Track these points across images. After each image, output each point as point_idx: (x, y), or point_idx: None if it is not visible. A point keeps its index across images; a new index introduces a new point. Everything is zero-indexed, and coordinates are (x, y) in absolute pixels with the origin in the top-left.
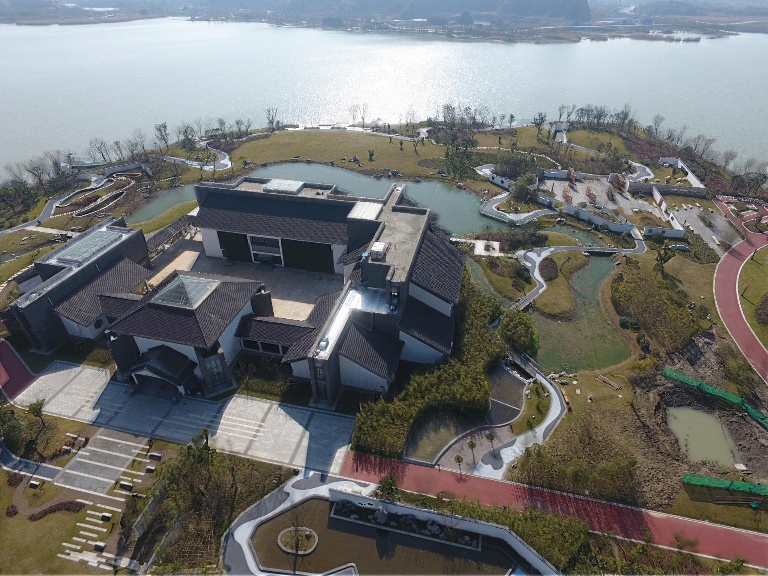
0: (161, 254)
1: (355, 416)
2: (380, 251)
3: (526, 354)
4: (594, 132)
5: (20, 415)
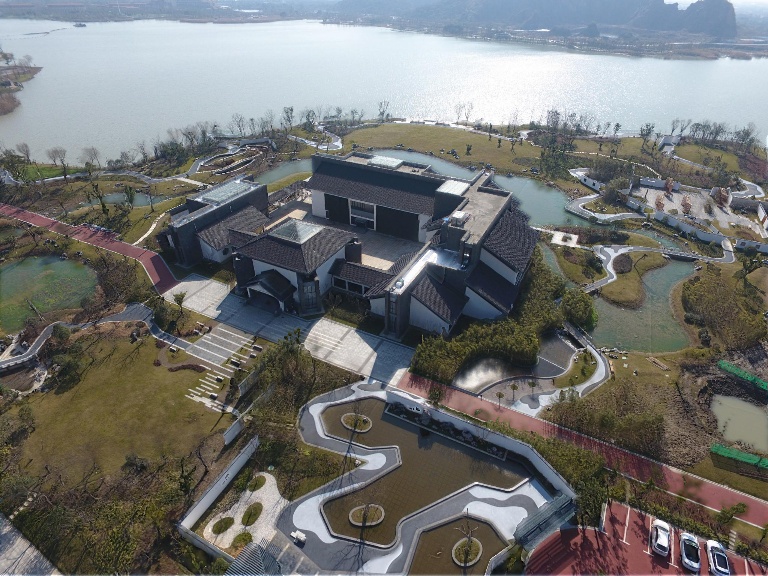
0: (277, 209)
1: None
2: (460, 218)
3: (582, 328)
4: (707, 148)
5: (166, 304)
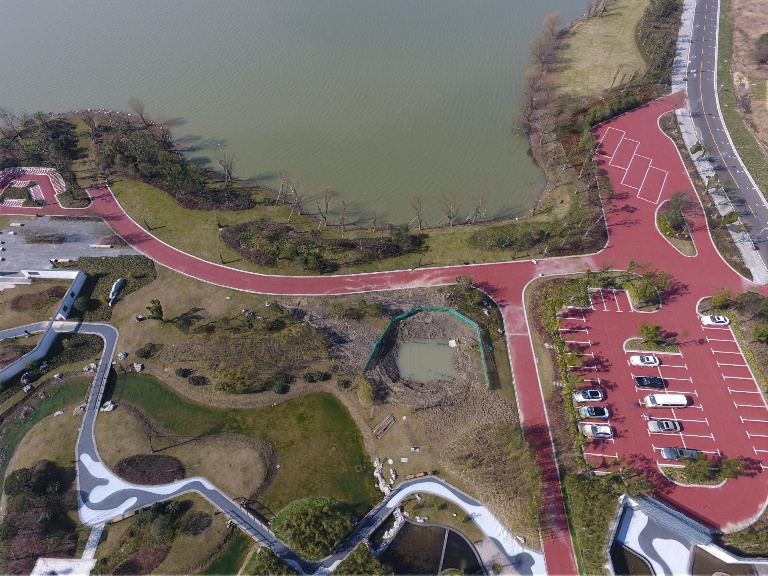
0: None
1: None
2: None
3: None
4: None
5: None
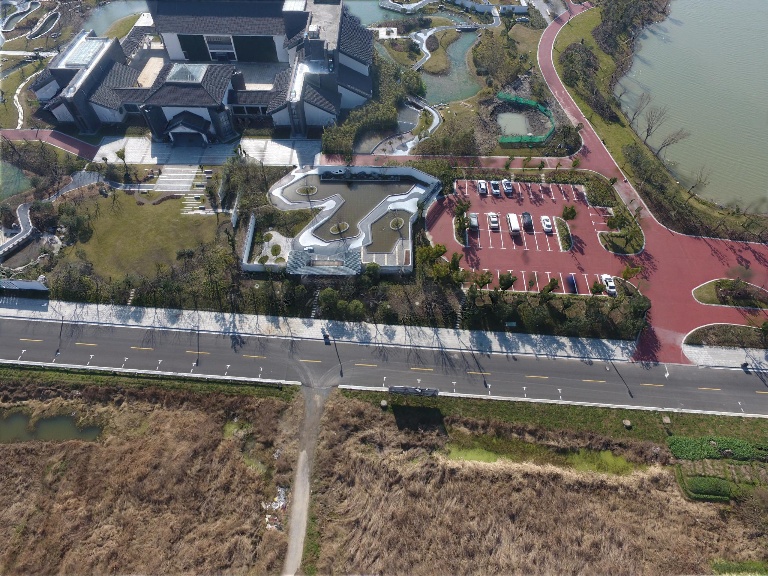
0: (131, 62)
1: (320, 139)
2: (315, 31)
3: (418, 96)
4: None
5: (106, 165)
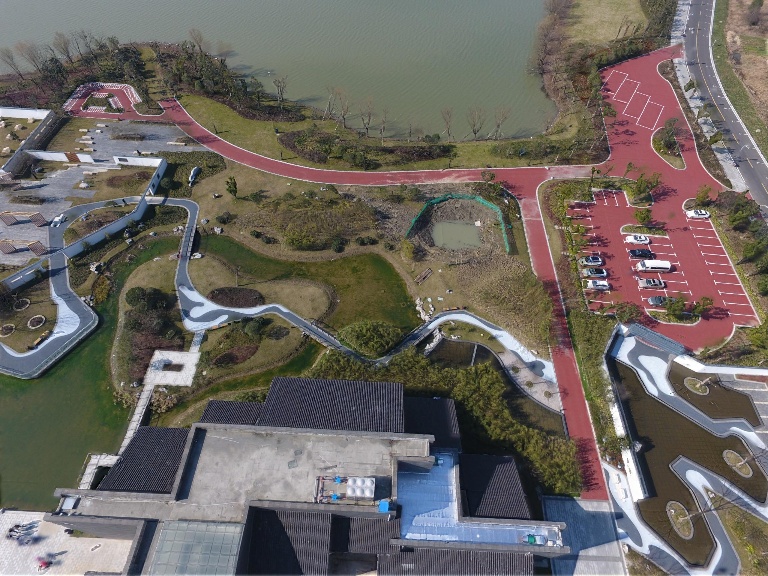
0: None
1: (542, 502)
2: None
3: None
4: None
5: None
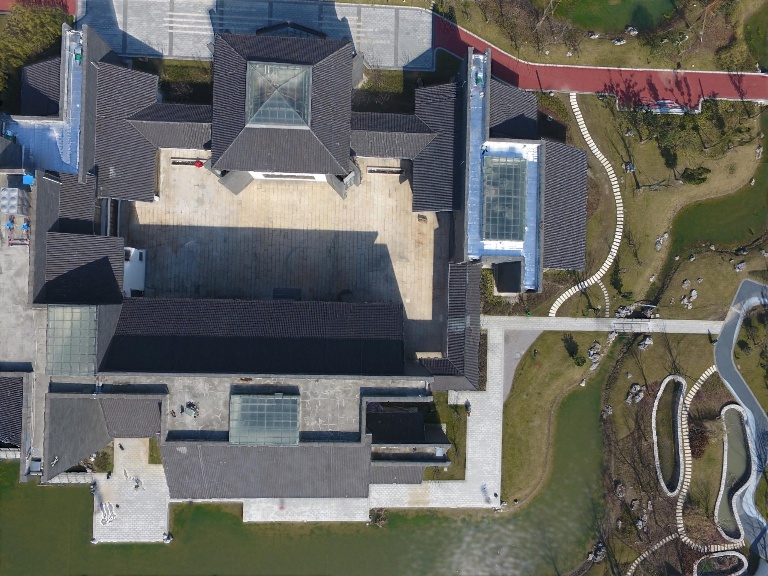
0: None
1: None
2: (3, 188)
3: None
4: None
5: None
